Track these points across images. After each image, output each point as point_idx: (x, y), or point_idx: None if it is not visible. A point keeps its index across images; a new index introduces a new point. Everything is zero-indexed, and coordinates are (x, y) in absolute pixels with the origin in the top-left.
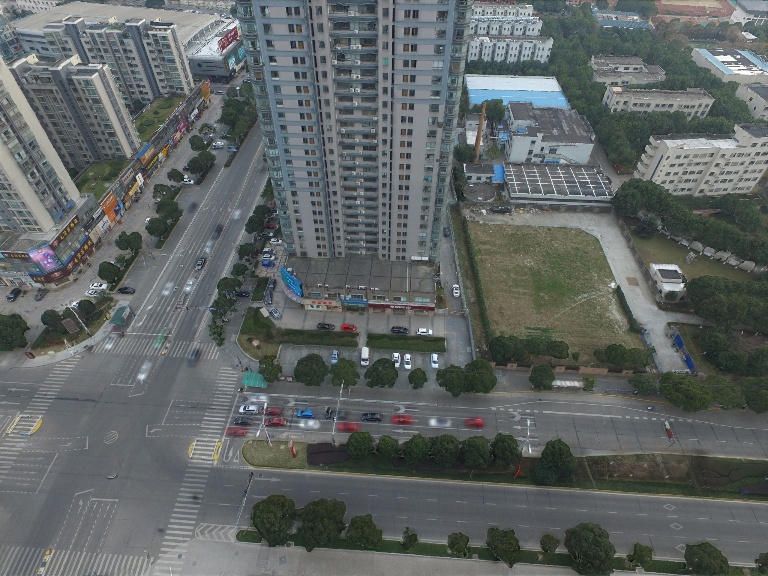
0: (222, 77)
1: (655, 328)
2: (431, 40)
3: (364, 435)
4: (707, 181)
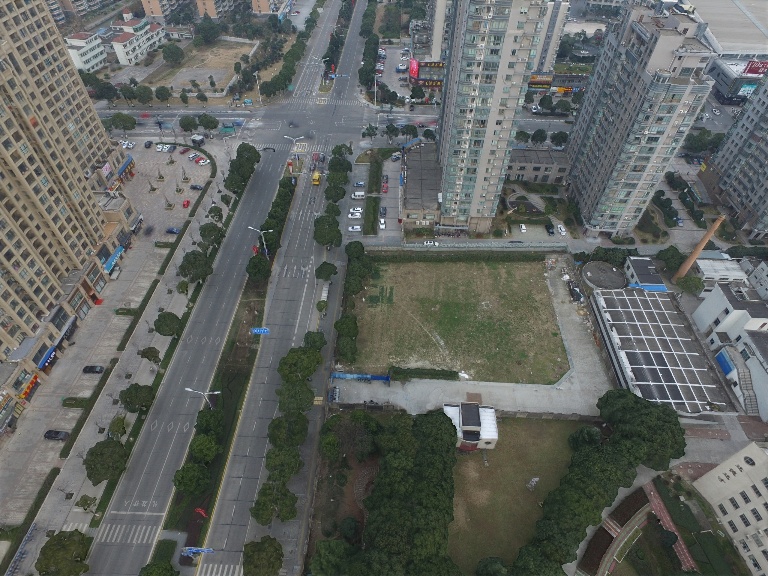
0: (723, 96)
1: (398, 395)
2: None
3: (286, 180)
4: None
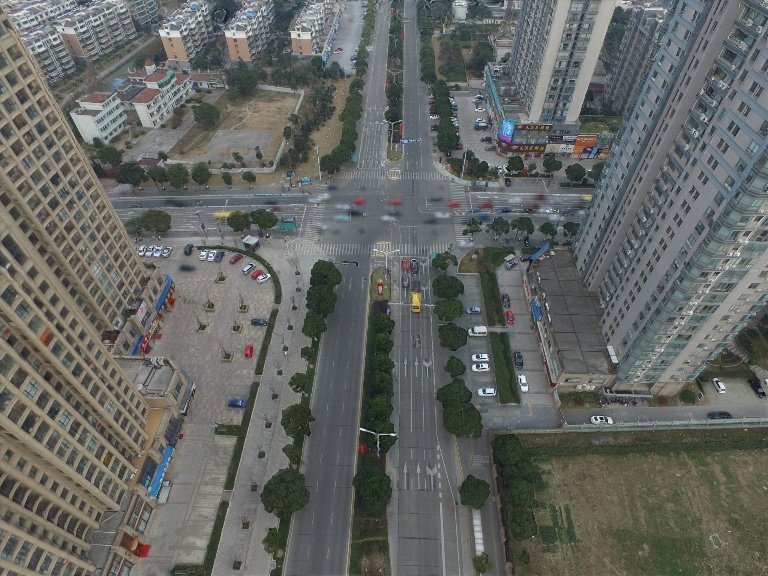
0: None
1: None
2: (766, 112)
3: (386, 319)
4: None
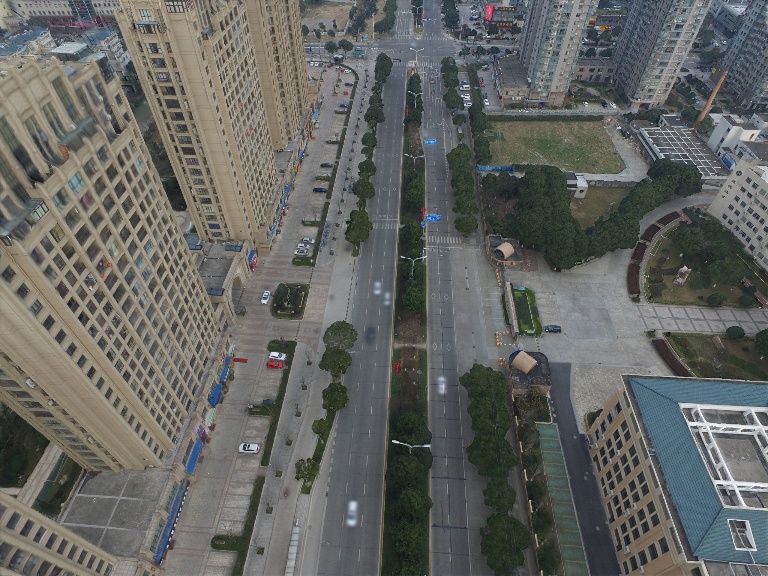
0: (729, 31)
1: (520, 177)
2: None
3: (417, 74)
4: (761, 237)
